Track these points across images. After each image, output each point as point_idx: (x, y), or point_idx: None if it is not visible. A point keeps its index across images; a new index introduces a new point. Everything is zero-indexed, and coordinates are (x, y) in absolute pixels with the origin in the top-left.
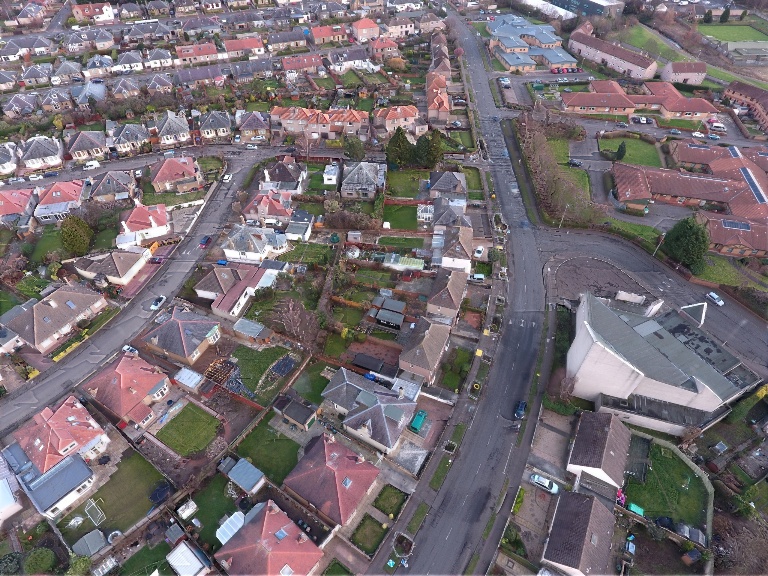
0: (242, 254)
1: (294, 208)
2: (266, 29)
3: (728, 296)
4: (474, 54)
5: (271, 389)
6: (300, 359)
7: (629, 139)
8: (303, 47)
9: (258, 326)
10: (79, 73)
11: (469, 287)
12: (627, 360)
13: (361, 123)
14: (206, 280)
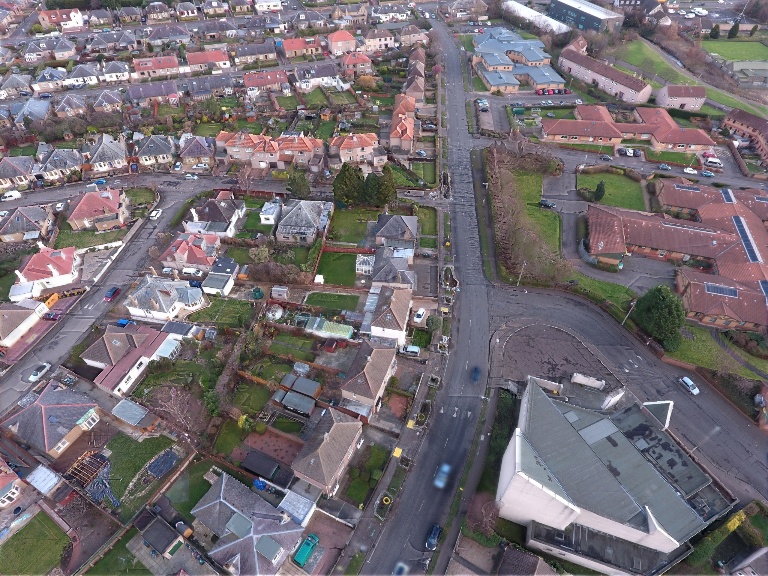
0: (147, 312)
1: (221, 253)
2: (237, 40)
3: (705, 381)
4: (455, 71)
5: (141, 496)
6: (184, 454)
7: (612, 175)
8: (273, 60)
9: (141, 410)
10: (27, 87)
11: (401, 362)
12: (564, 484)
13: (314, 152)
14: (94, 348)
